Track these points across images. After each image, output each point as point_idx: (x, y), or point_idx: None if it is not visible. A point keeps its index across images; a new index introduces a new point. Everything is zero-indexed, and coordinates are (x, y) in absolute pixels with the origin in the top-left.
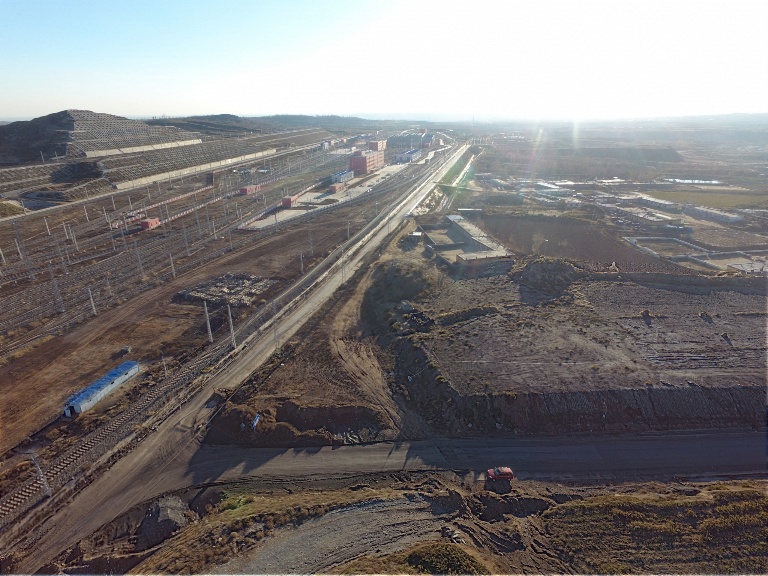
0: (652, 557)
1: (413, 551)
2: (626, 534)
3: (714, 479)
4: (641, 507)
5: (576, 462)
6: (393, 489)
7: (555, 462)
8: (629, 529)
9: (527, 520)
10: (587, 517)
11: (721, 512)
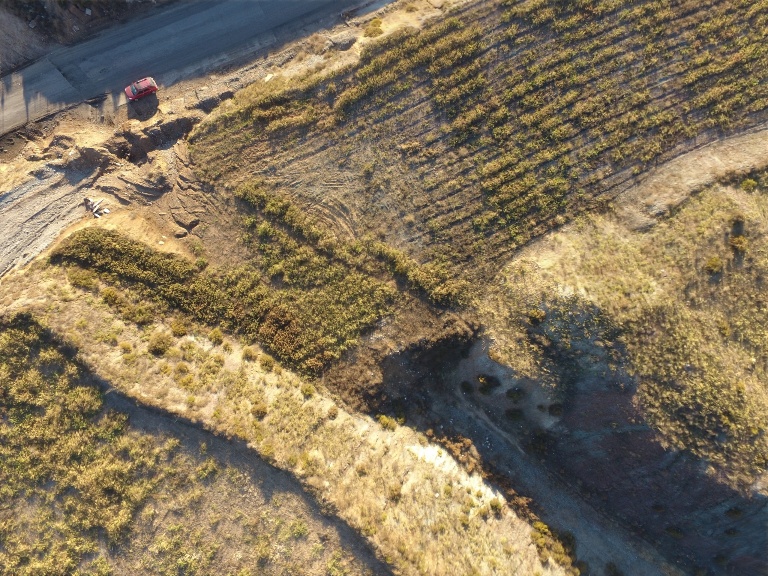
0: (284, 160)
1: (51, 252)
2: (264, 140)
3: (384, 3)
4: (282, 98)
5: (231, 30)
6: (24, 159)
7: (206, 41)
8: (267, 133)
9: (172, 151)
10: (228, 131)
11: (360, 77)
